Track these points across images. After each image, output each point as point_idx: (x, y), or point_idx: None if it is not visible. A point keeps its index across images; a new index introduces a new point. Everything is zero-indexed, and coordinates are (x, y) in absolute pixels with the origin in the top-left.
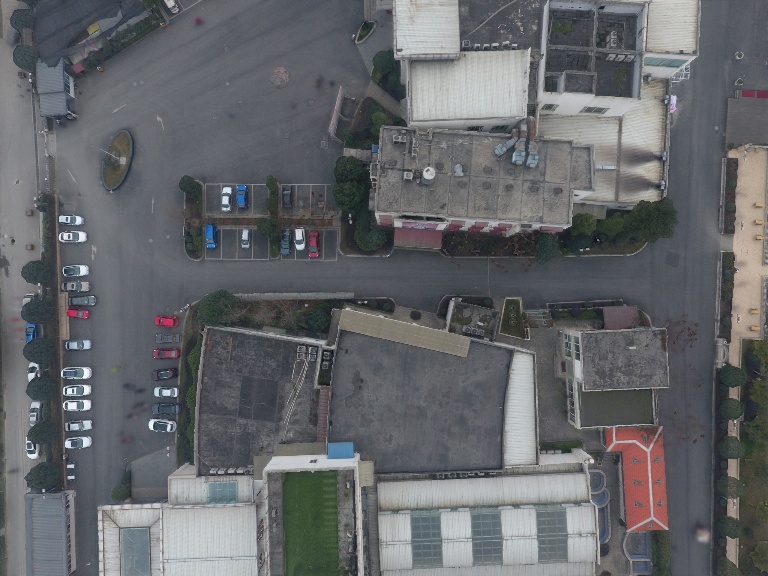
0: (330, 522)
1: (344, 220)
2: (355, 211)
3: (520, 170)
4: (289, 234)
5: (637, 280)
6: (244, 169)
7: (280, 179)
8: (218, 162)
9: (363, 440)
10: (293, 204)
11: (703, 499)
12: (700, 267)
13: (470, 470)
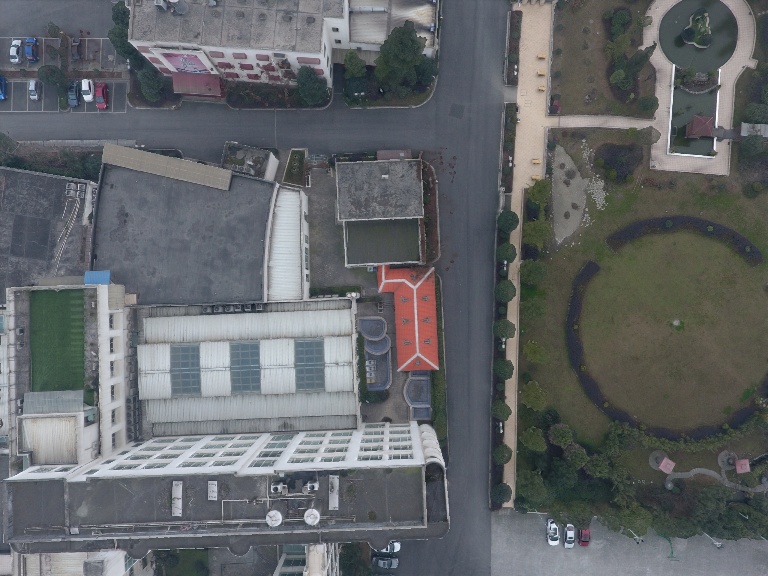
0: (77, 342)
1: (132, 72)
2: (134, 57)
3: (274, 0)
4: (76, 85)
5: (422, 131)
6: (35, 23)
7: (71, 33)
8: (10, 16)
9: (127, 273)
10: (83, 57)
11: (484, 346)
12: (484, 119)
13: (230, 301)
